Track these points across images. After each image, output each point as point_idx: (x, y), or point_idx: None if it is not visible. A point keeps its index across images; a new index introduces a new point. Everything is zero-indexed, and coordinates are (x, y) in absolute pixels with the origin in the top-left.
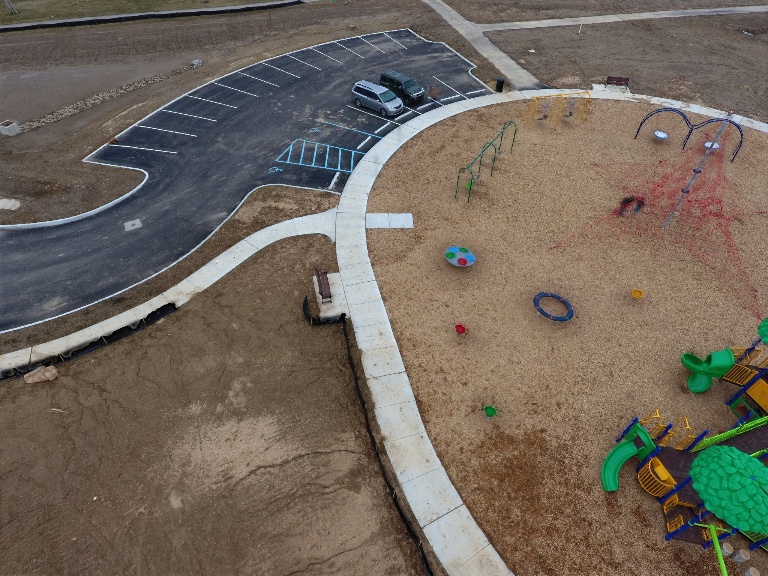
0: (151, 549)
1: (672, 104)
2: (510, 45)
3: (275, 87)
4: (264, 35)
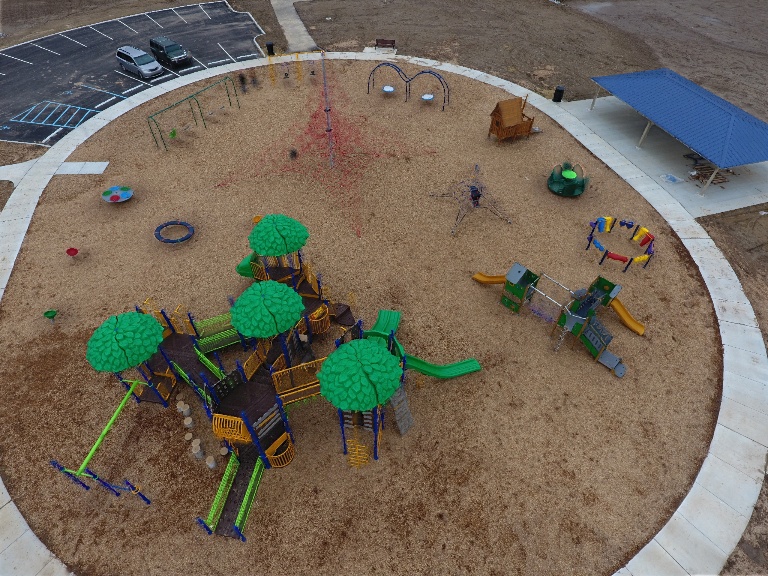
0: None
1: (426, 63)
2: (311, 14)
3: (56, 55)
4: (81, 9)
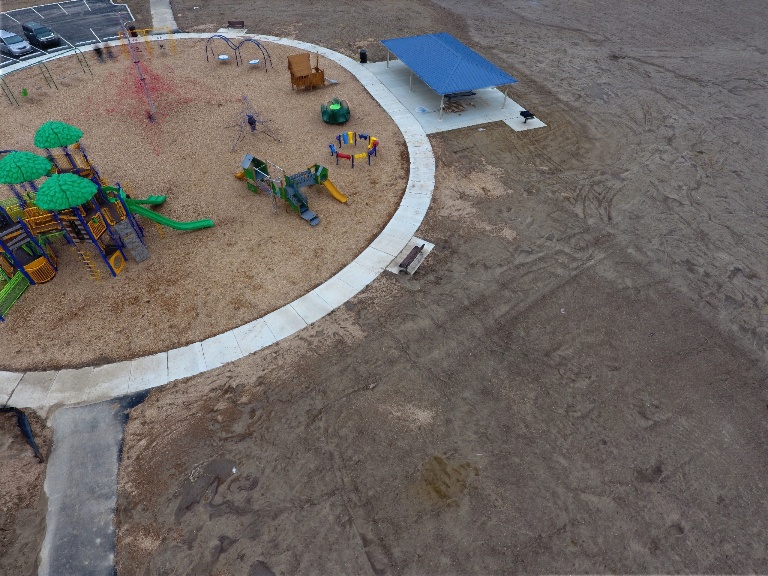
0: None
1: (268, 39)
2: (182, 4)
3: None
4: None
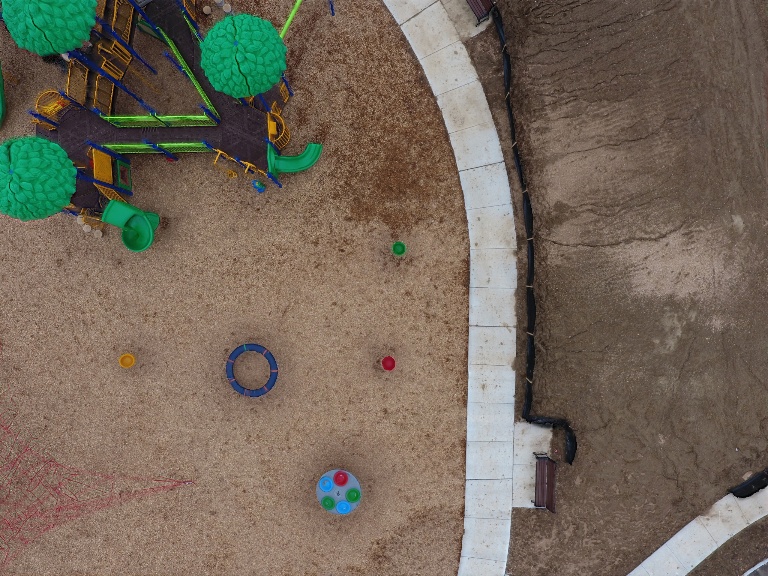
0: (759, 183)
1: None
2: None
3: None
4: None
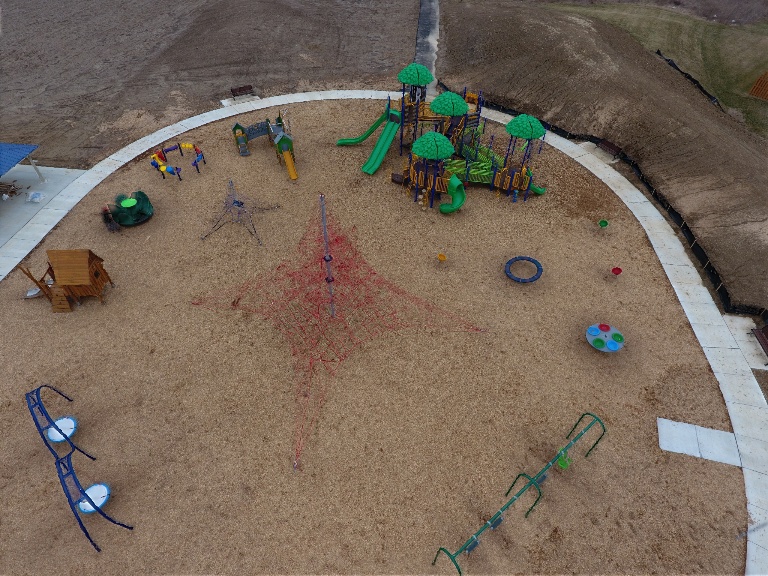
0: None
1: None
2: None
3: None
4: None
